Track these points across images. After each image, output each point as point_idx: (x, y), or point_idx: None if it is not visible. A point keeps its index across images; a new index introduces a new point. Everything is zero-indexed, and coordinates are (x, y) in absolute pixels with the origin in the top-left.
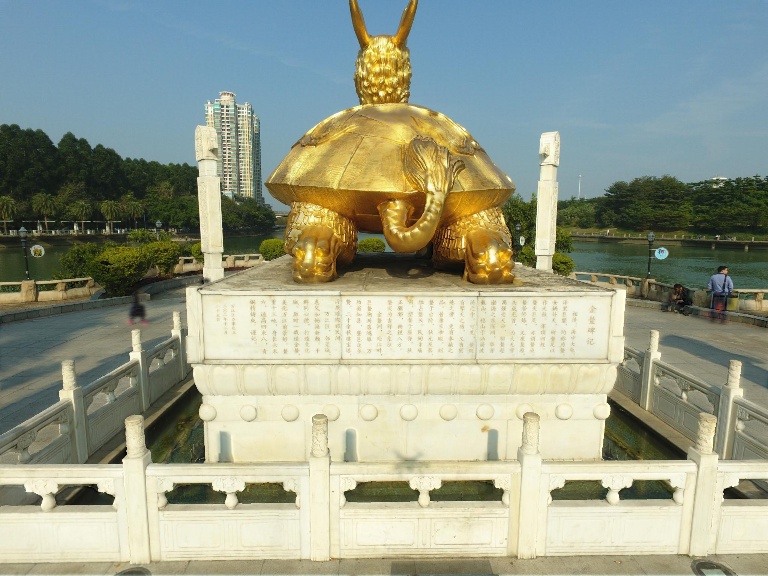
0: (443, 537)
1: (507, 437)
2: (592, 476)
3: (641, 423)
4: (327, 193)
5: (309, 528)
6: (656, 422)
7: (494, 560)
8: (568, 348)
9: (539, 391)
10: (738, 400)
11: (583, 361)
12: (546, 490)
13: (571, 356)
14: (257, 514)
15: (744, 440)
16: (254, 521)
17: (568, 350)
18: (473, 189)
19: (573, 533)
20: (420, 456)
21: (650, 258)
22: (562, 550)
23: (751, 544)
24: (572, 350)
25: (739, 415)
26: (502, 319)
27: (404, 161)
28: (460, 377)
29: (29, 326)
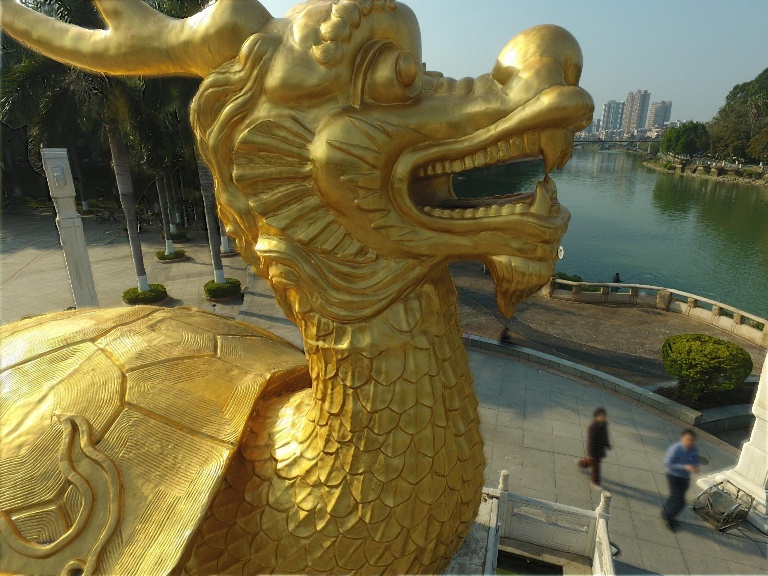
0: None
1: None
2: None
3: None
4: None
5: None
6: None
7: None
8: None
9: None
10: None
11: None
12: None
13: None
14: None
15: None
16: None
17: None
18: None
19: None
20: None
21: None
22: None
23: None
24: None
25: None
26: None
27: None
28: None
29: (514, 373)
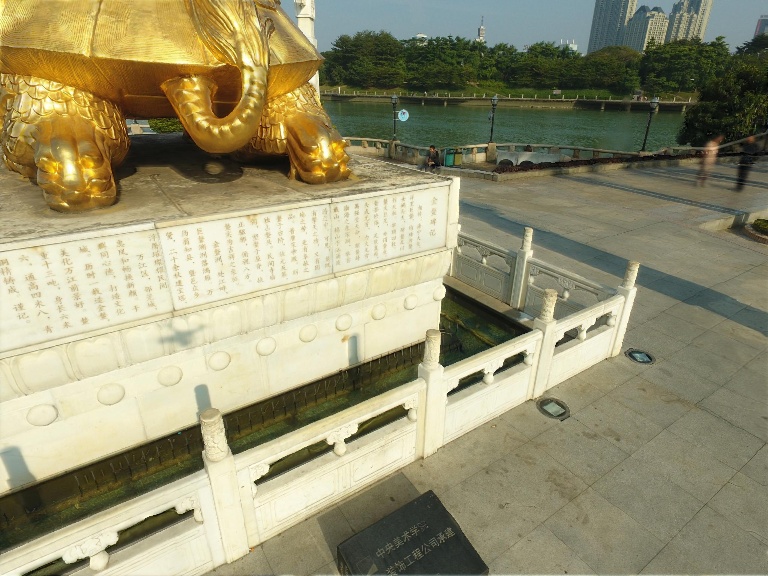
0: (362, 472)
1: (365, 340)
2: (478, 368)
3: (451, 289)
4: (71, 62)
5: (219, 535)
6: (462, 286)
7: (406, 470)
8: (415, 243)
9: (390, 289)
10: (531, 260)
11: (427, 253)
12: (445, 394)
13: (417, 250)
14: (145, 556)
15: (535, 291)
16: (142, 565)
17: (415, 245)
18: (291, 61)
19: (463, 419)
20: (284, 385)
21: (395, 120)
22: (454, 435)
23: (564, 375)
24: (418, 244)
25: (531, 272)
26: (356, 225)
27: (193, 15)
28: (318, 295)
29: None
